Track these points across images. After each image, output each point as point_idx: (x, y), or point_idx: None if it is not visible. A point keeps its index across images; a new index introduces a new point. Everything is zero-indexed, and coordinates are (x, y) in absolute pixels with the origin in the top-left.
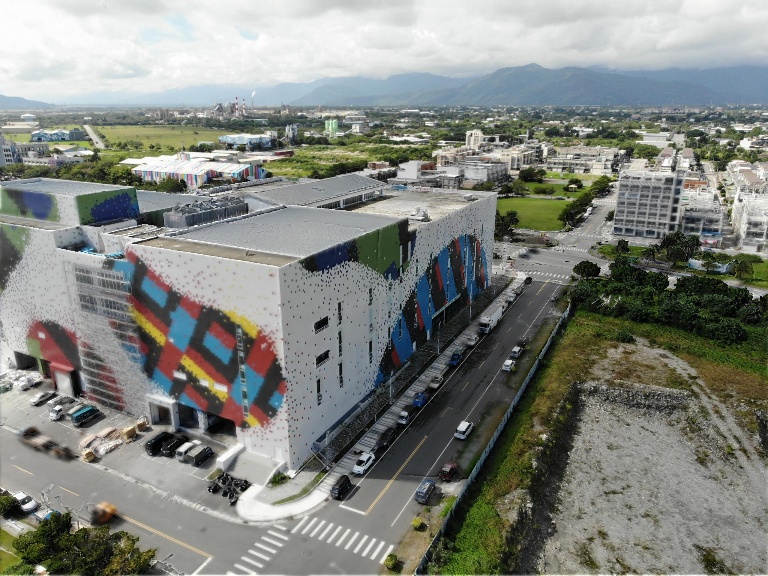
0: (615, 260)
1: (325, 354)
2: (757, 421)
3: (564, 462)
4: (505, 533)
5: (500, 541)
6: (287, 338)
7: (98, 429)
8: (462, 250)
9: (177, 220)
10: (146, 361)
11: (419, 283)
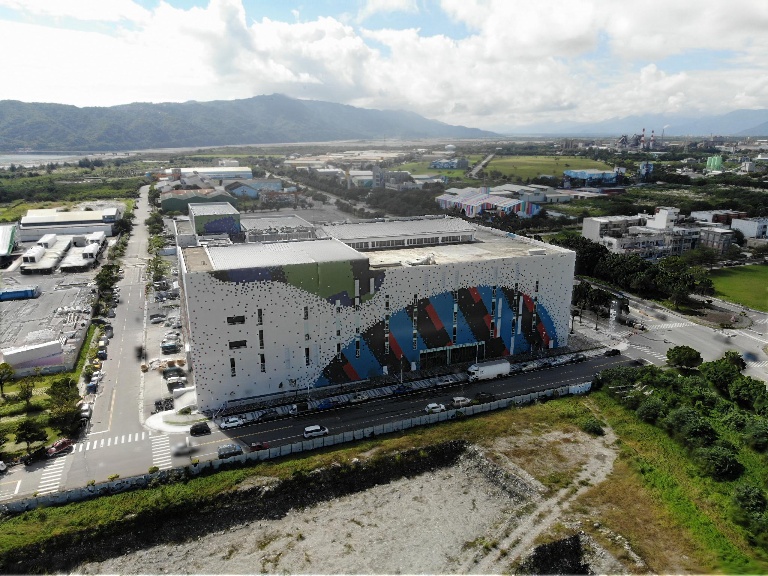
0: None
1: (245, 343)
2: (562, 540)
3: (363, 488)
4: (225, 492)
5: (213, 493)
6: (195, 320)
7: (168, 357)
8: (487, 300)
9: None
10: None
11: (393, 316)
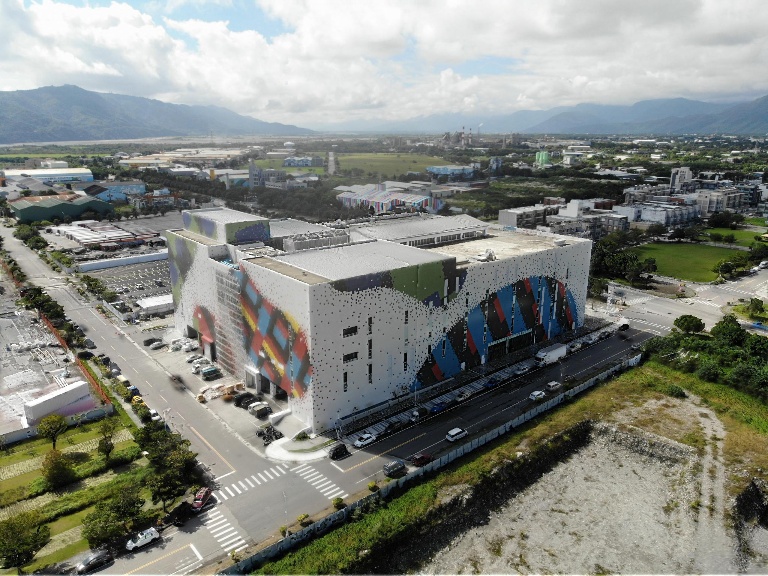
0: (724, 318)
1: (355, 354)
2: (747, 488)
3: (534, 479)
4: (432, 508)
5: (422, 511)
6: (315, 336)
7: (215, 383)
8: (535, 290)
9: (290, 245)
10: (246, 341)
11: (470, 313)
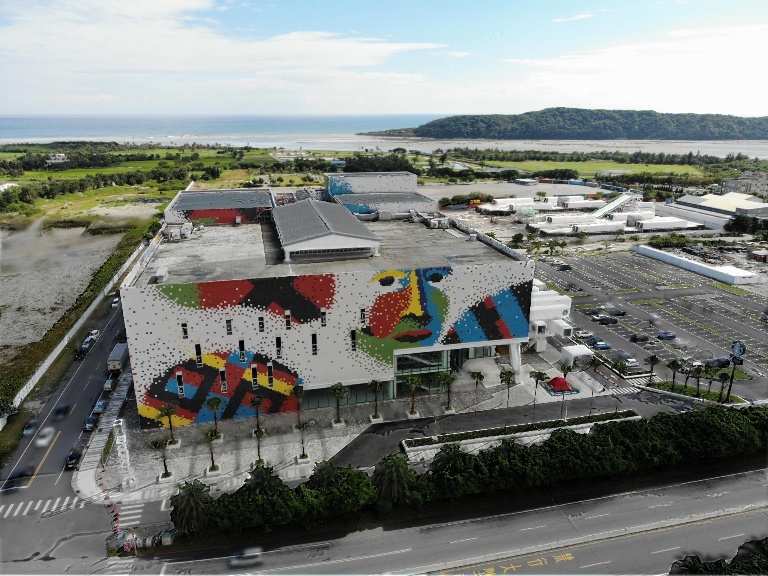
0: None
1: None
2: None
3: None
4: None
5: (91, 287)
6: None
7: None
8: None
9: None
10: None
11: None
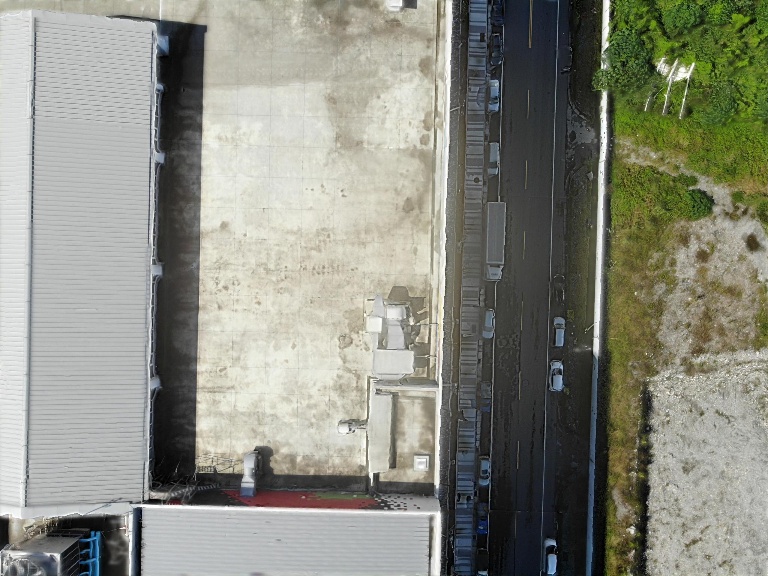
0: None
1: None
2: None
3: (644, 518)
4: None
5: None
6: None
7: None
8: None
9: None
10: None
11: None
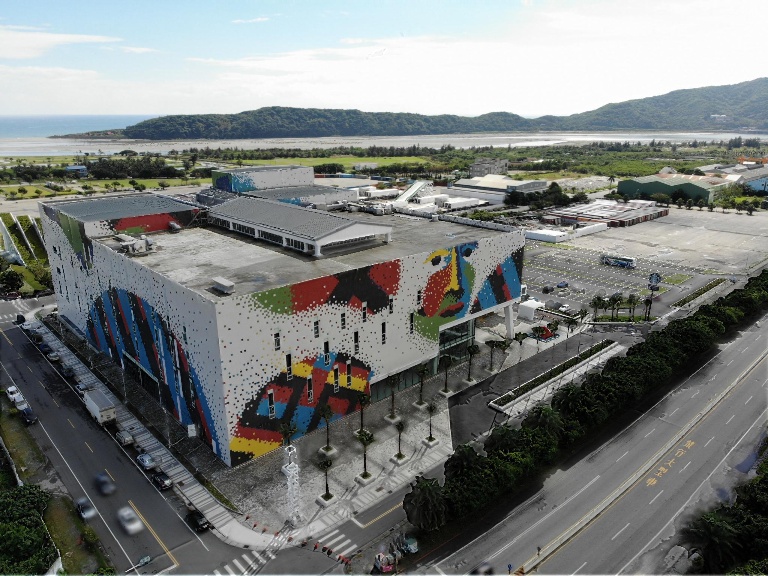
0: None
1: None
2: None
3: None
4: None
5: None
6: None
7: None
8: None
9: None
10: None
11: None
